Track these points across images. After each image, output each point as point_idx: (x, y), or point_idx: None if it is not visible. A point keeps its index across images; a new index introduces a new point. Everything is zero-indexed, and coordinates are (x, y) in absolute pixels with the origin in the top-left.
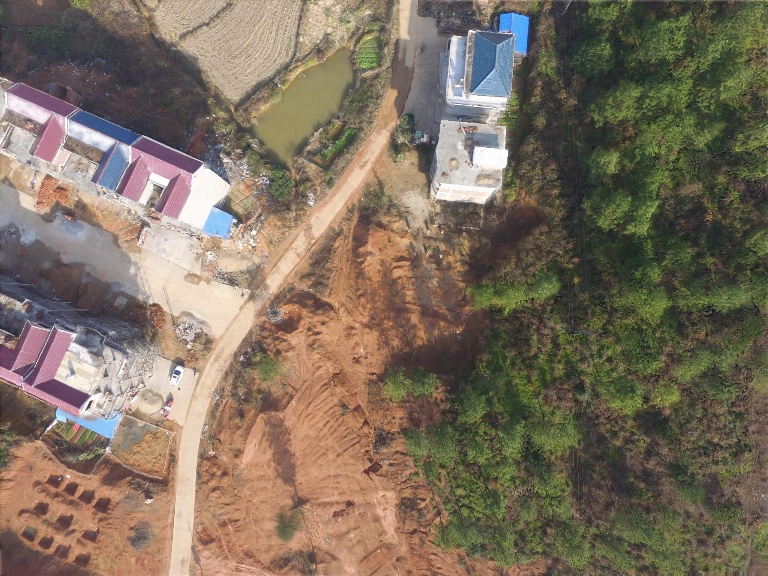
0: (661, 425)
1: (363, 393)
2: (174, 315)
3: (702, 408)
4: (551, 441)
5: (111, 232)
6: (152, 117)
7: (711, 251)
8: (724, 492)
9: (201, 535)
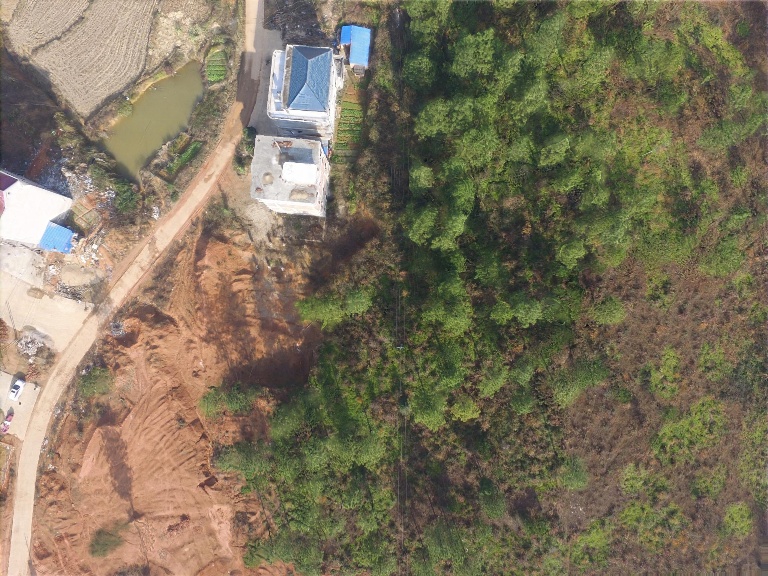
0: (480, 439)
1: (202, 407)
2: (17, 329)
3: (519, 422)
4: (377, 455)
5: None
6: None
7: (530, 264)
8: (542, 506)
9: (38, 549)
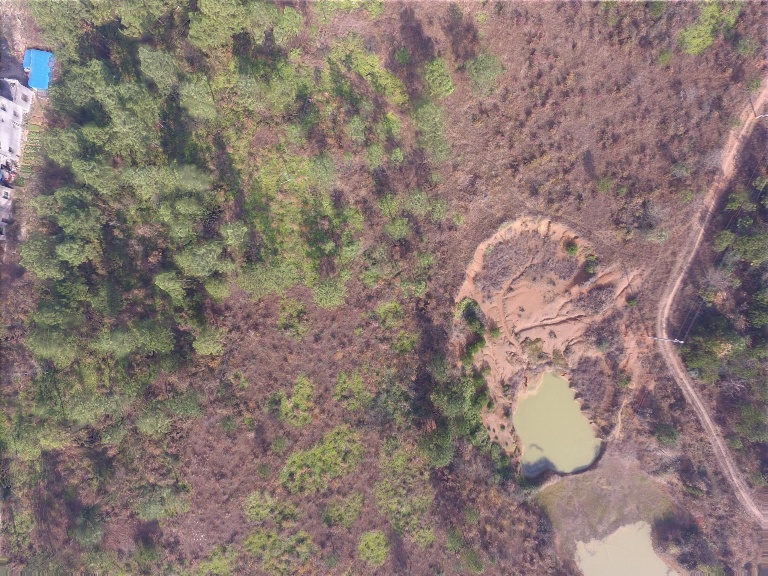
0: None
1: None
2: None
3: (142, 448)
4: (20, 478)
5: None
6: None
7: None
8: (164, 532)
9: None
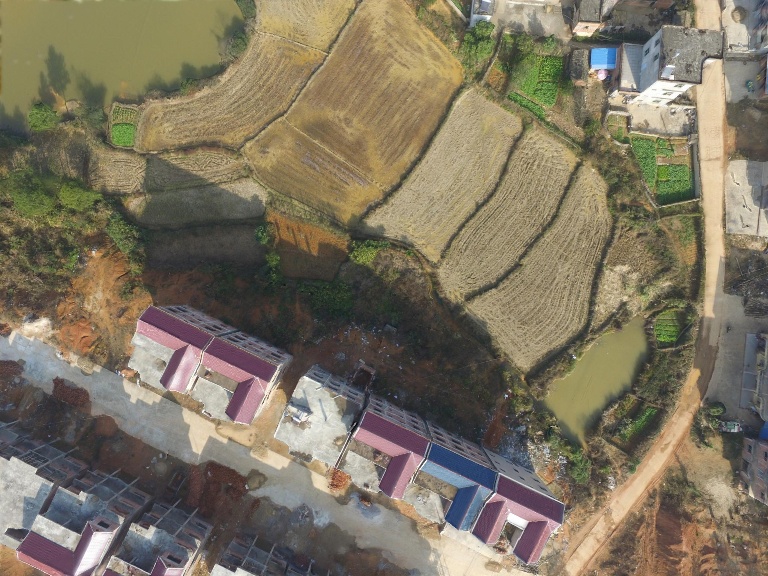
0: None
1: None
2: None
3: None
4: None
5: (409, 517)
6: (450, 395)
7: None
8: None
9: None
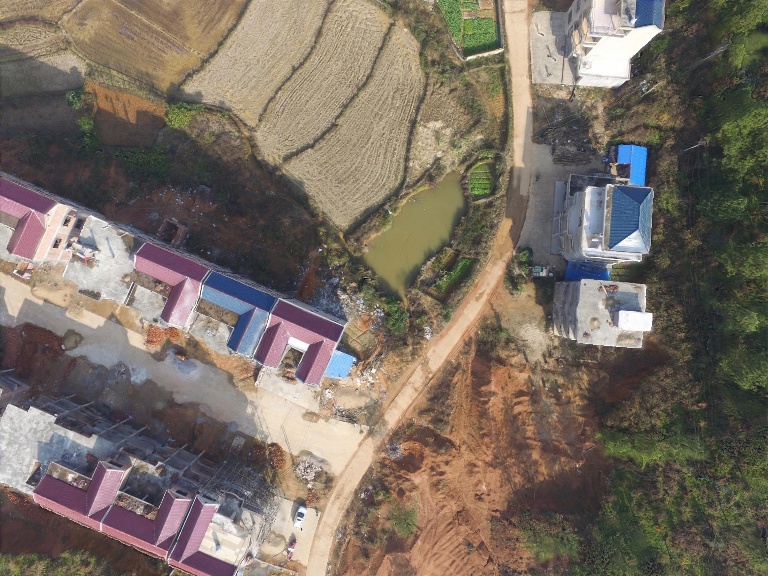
0: None
1: (486, 529)
2: (293, 454)
3: None
4: None
5: (225, 370)
6: (263, 250)
7: None
8: None
9: None
